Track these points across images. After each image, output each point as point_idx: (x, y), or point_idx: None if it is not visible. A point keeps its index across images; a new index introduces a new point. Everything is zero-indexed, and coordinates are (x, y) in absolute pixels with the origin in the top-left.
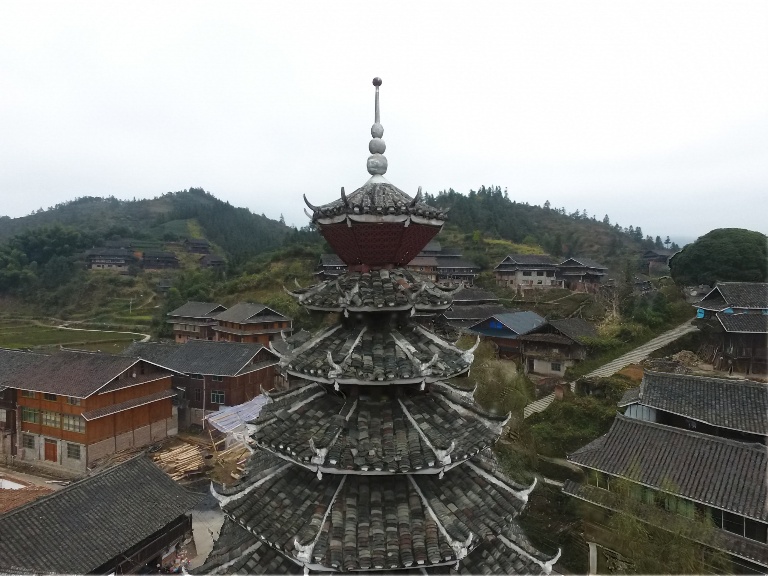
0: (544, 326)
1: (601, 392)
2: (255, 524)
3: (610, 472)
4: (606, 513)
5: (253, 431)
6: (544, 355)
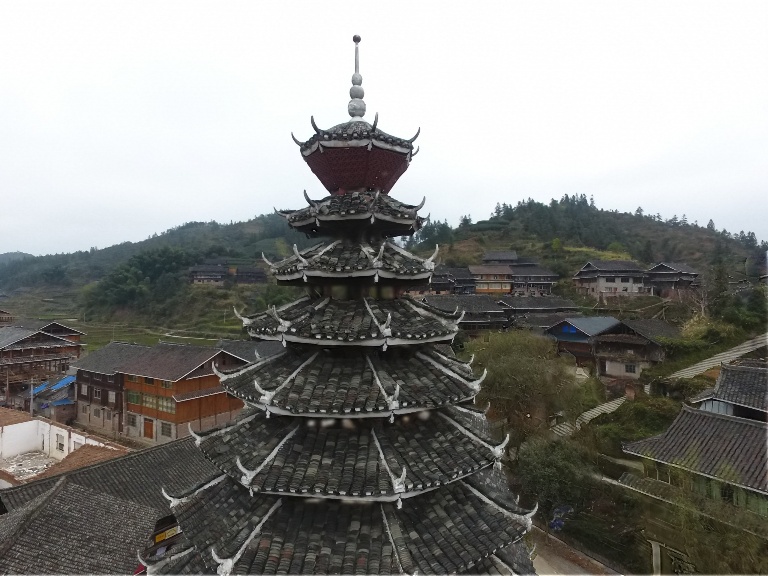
0: (617, 326)
1: (680, 394)
2: (240, 389)
3: (669, 462)
4: (668, 508)
5: (247, 323)
6: (617, 356)
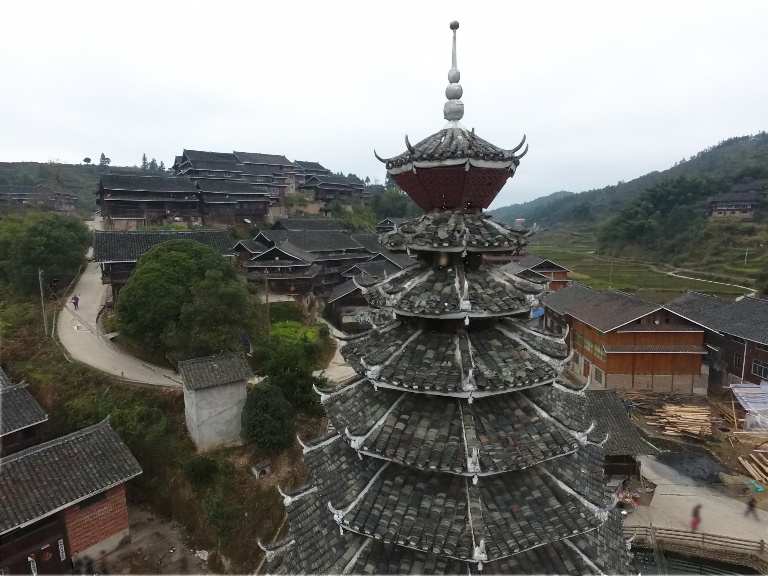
0: None
1: None
2: None
3: None
4: None
5: None
6: None
